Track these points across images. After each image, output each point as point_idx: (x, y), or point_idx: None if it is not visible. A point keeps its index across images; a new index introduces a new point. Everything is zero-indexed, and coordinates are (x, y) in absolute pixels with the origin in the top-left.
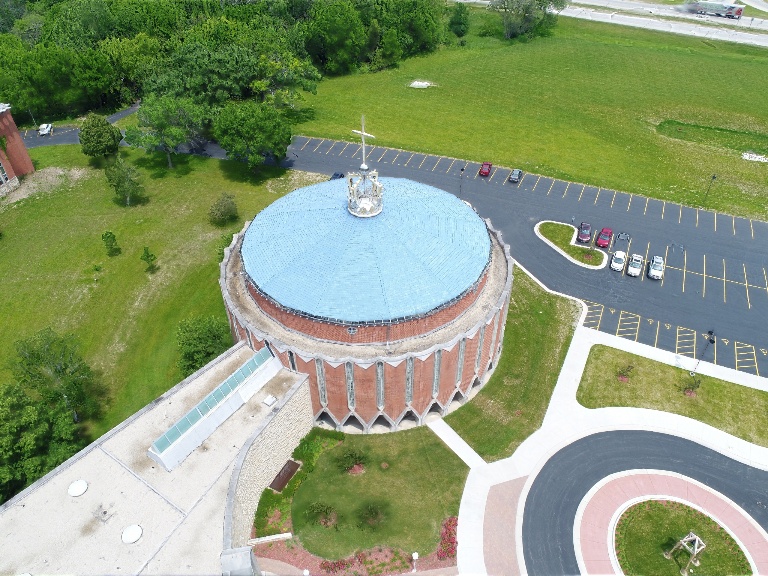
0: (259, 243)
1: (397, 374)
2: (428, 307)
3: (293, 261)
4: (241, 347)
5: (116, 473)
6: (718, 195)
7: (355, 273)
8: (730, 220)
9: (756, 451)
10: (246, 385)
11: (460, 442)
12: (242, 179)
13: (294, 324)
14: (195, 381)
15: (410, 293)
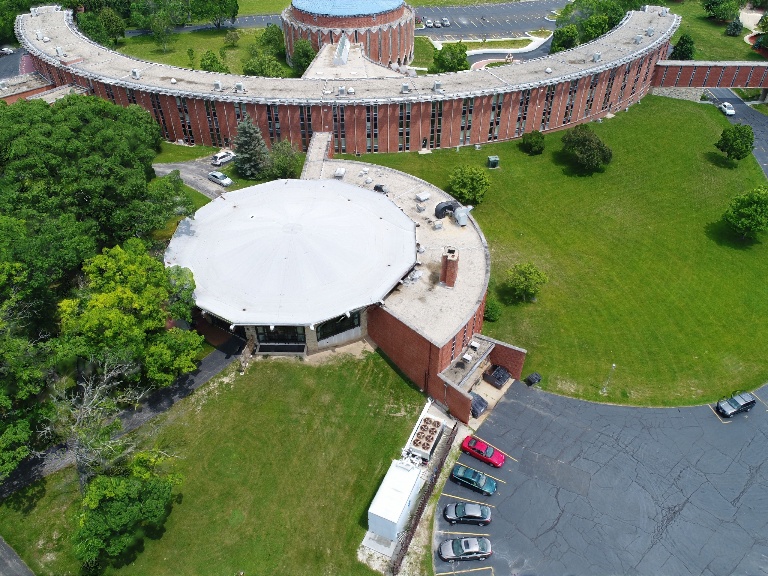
0: (310, 6)
1: (395, 34)
2: (396, 7)
3: (334, 4)
4: (326, 45)
5: (327, 69)
6: (450, 3)
7: (362, 1)
8: (461, 8)
9: (512, 50)
10: (346, 45)
11: (420, 68)
12: (215, 37)
13: (349, 25)
14: (322, 53)
15: (386, 4)
